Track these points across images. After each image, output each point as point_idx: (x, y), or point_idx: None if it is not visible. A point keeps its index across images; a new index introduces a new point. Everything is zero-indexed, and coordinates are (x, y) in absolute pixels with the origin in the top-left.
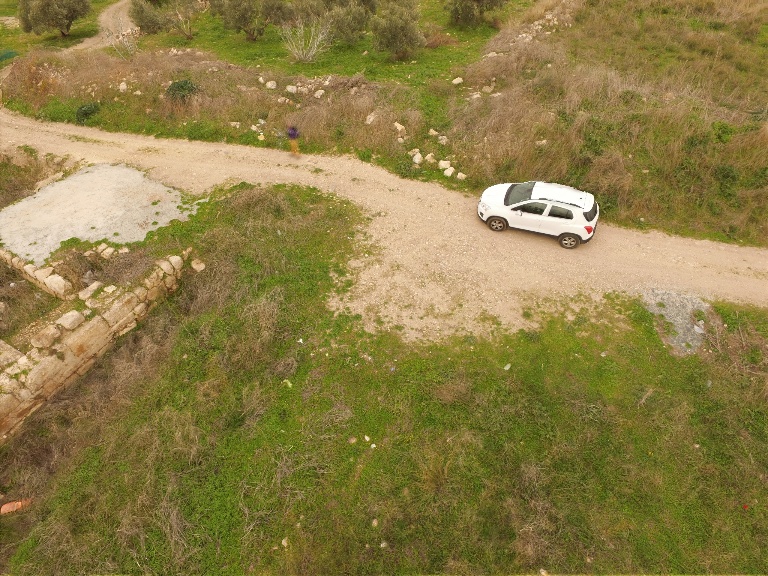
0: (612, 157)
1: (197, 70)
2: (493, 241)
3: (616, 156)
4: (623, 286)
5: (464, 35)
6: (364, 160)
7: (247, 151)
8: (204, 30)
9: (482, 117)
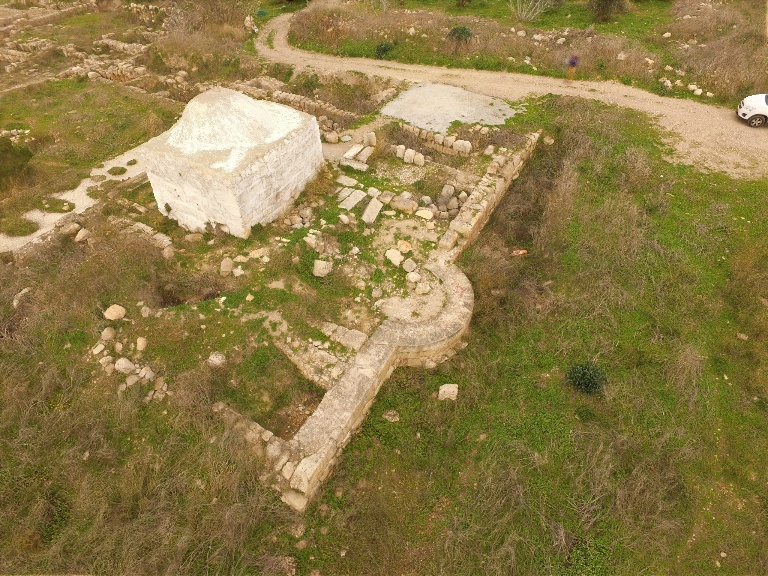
0: None
1: (463, 21)
2: (755, 133)
3: None
4: None
5: (642, 5)
6: (627, 84)
7: (528, 77)
8: None
9: (706, 58)
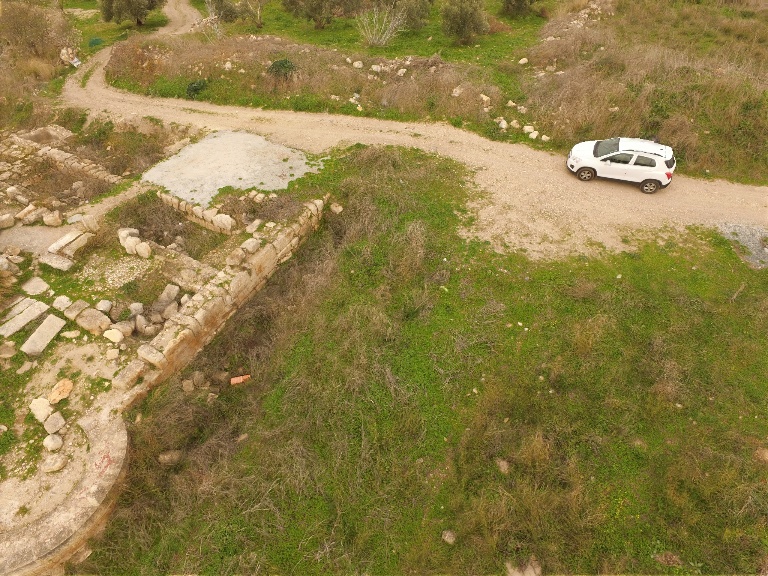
0: (678, 120)
1: (291, 51)
2: (583, 188)
3: (682, 119)
4: (700, 221)
5: (516, 23)
6: (456, 126)
7: (349, 120)
8: (268, 20)
9: (554, 90)
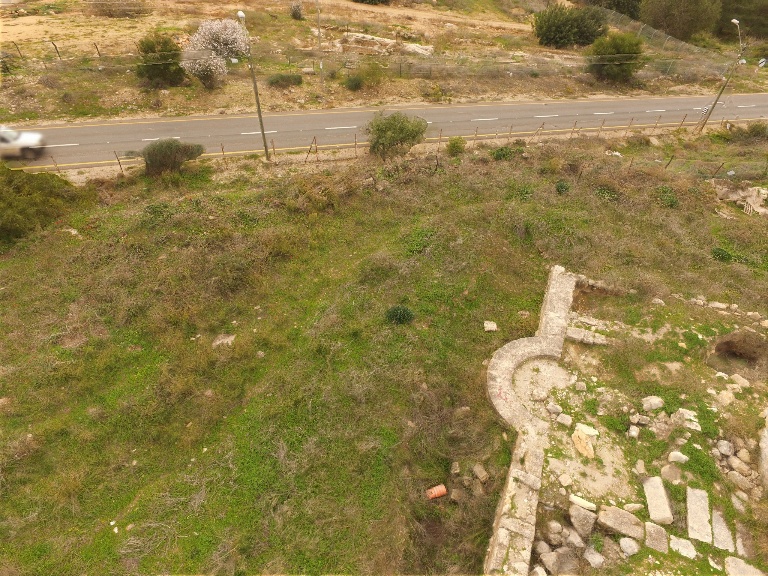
0: None
1: None
2: None
3: None
4: None
5: None
6: None
7: None
8: None
9: None
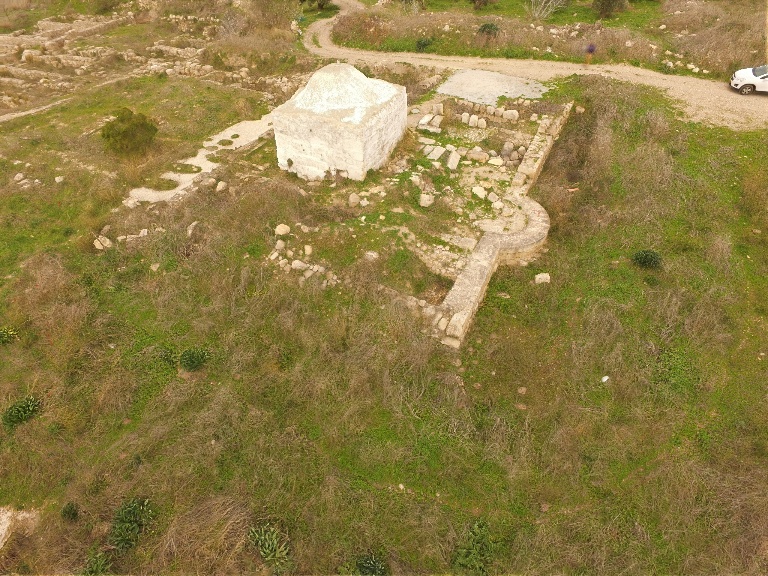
0: None
1: (489, 19)
2: (746, 99)
3: None
4: None
5: (635, 5)
6: (636, 66)
7: (551, 63)
8: None
9: (698, 44)
